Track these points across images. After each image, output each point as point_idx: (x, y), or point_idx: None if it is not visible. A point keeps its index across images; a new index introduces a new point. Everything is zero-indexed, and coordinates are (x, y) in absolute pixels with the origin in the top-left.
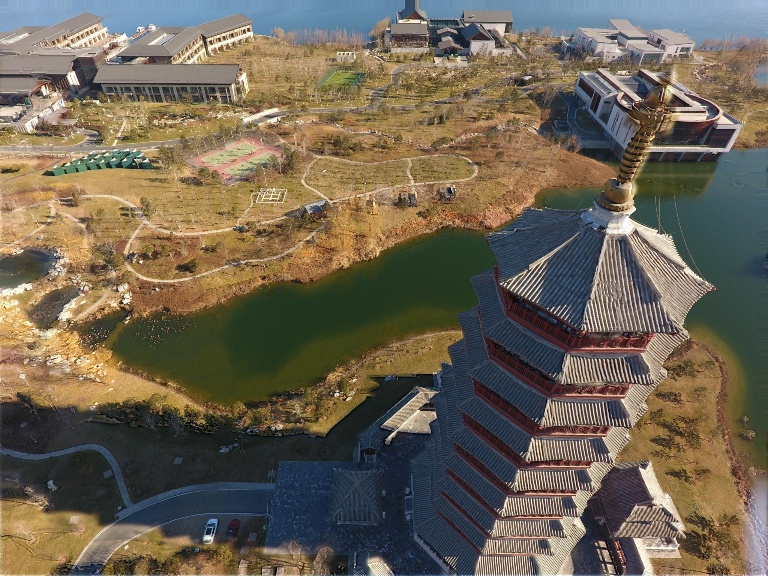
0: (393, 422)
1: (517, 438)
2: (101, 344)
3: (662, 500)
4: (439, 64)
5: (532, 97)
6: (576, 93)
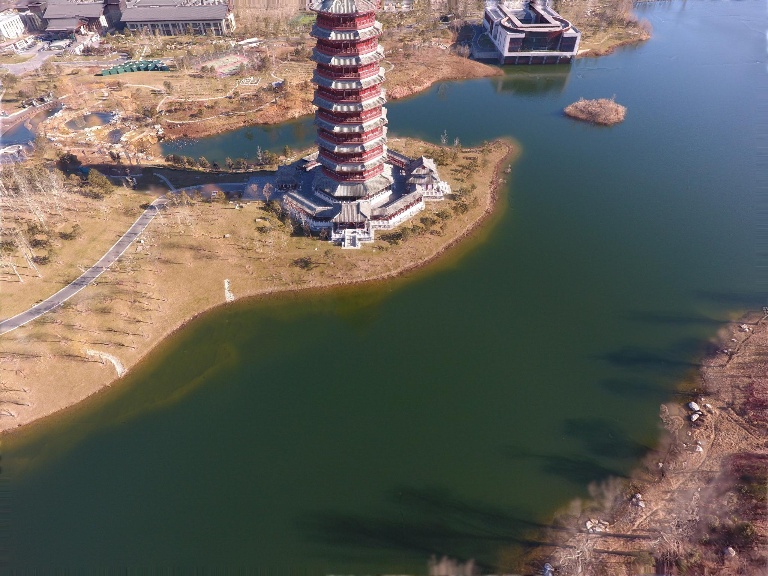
0: (310, 158)
1: None
2: (148, 149)
3: (431, 168)
4: (386, 10)
5: (449, 27)
6: (483, 24)
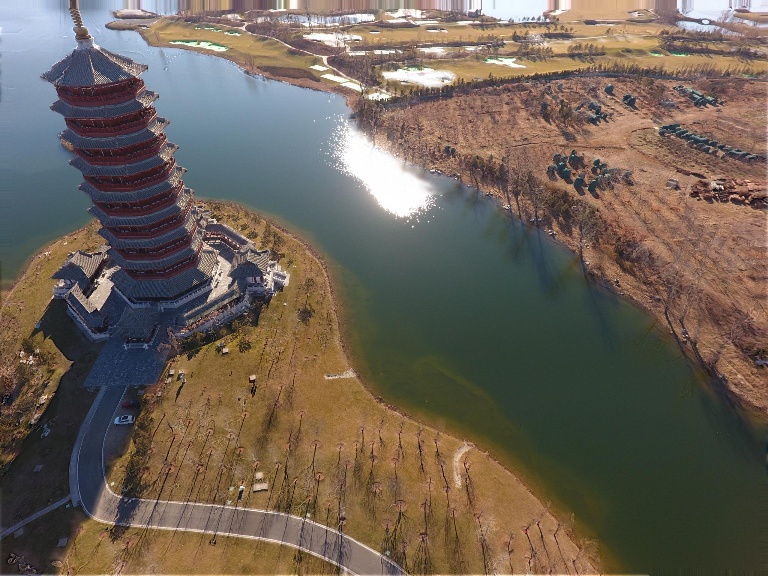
0: (89, 308)
1: (155, 162)
2: None
3: None
4: None
5: None
6: None
